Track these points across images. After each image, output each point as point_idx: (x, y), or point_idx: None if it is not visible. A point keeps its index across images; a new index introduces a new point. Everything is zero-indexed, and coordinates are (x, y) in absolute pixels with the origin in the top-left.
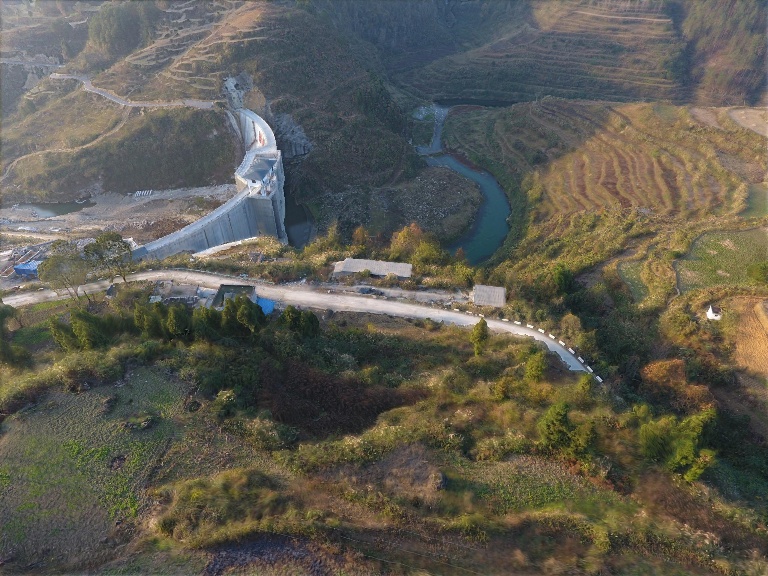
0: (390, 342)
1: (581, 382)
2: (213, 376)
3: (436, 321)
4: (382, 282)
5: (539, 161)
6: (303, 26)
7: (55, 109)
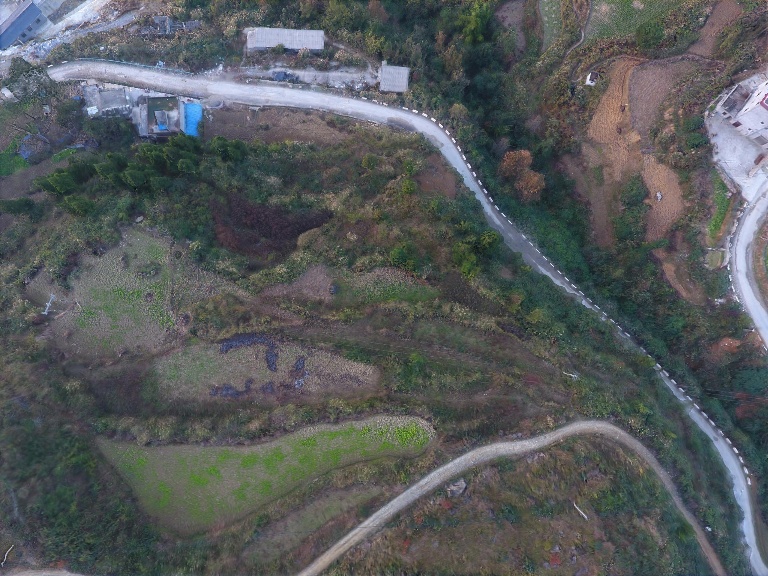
0: (305, 156)
1: (432, 205)
2: (181, 229)
3: (346, 113)
4: (295, 64)
5: None
6: None
7: None
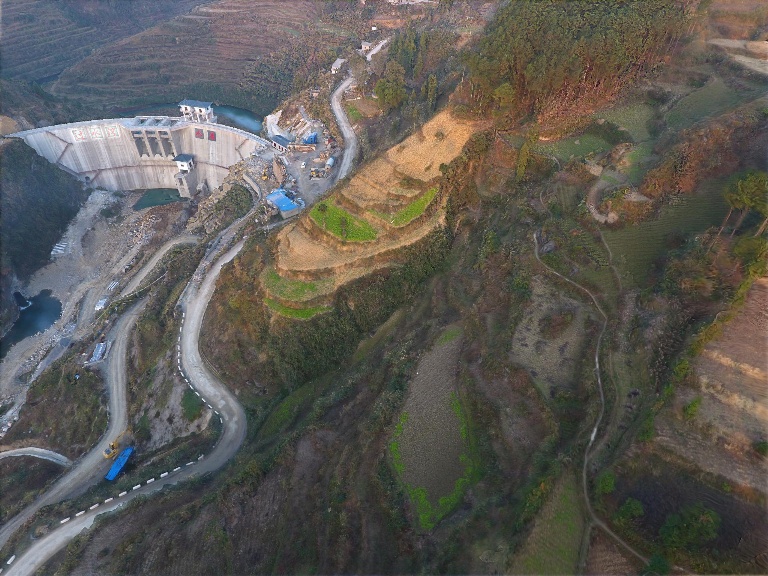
0: None
1: None
2: None
3: (378, 51)
4: None
5: (167, 79)
6: None
7: None
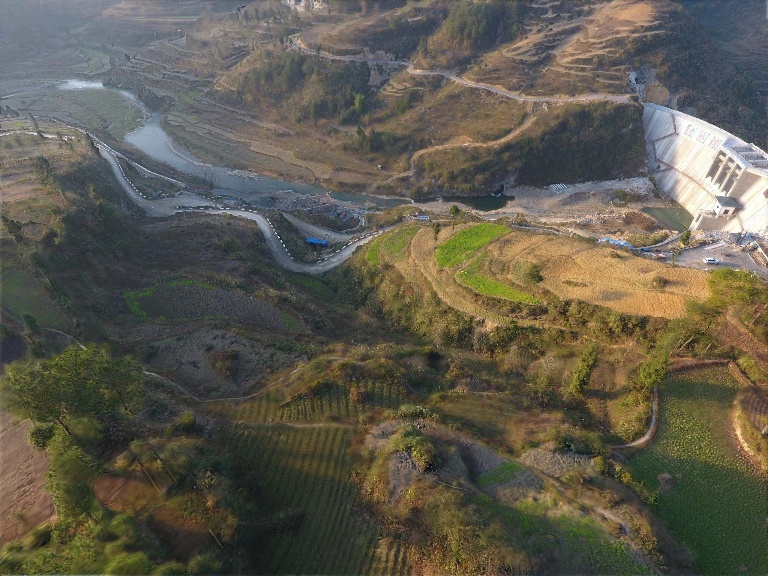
0: None
1: None
2: None
3: None
4: None
5: None
6: (686, 19)
7: (441, 105)
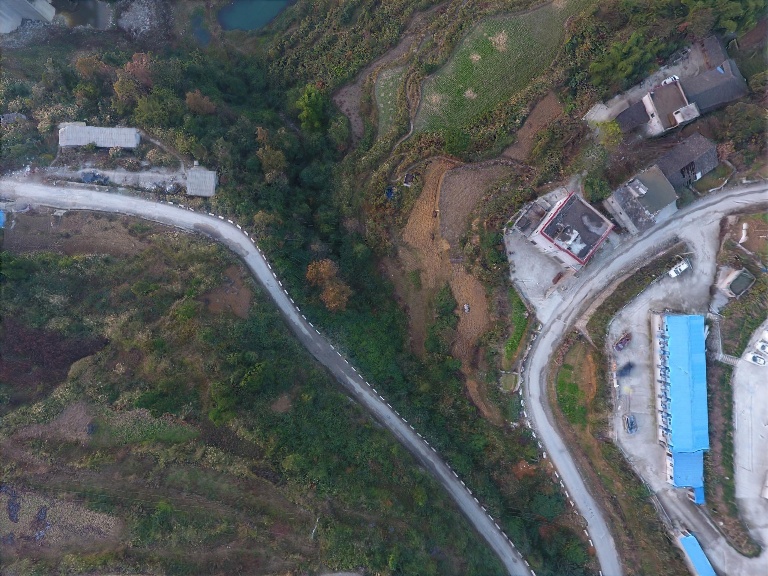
0: None
1: None
2: None
3: (153, 218)
4: (103, 165)
5: None
6: None
7: None
